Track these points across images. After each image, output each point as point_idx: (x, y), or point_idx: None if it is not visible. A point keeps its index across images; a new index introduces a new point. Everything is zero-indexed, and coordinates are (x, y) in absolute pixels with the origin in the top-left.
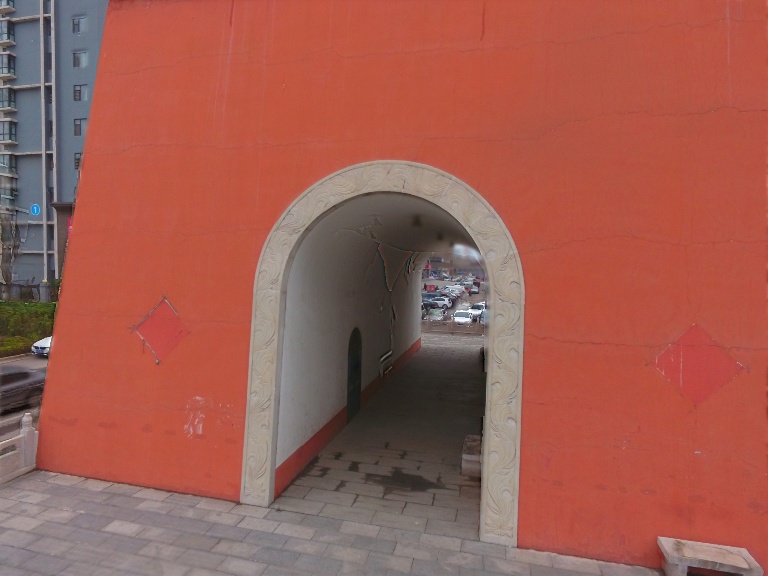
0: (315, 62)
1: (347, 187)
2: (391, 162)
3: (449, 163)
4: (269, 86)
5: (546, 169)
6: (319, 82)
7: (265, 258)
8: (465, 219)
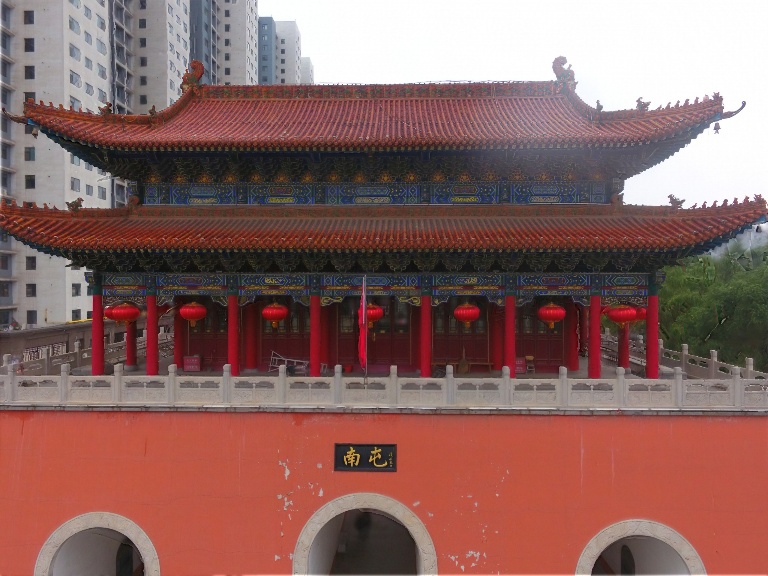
0: (67, 459)
1: (82, 524)
2: (103, 513)
3: (129, 514)
4: (43, 468)
5: (171, 518)
6: (69, 469)
7: (40, 560)
8: (136, 541)
